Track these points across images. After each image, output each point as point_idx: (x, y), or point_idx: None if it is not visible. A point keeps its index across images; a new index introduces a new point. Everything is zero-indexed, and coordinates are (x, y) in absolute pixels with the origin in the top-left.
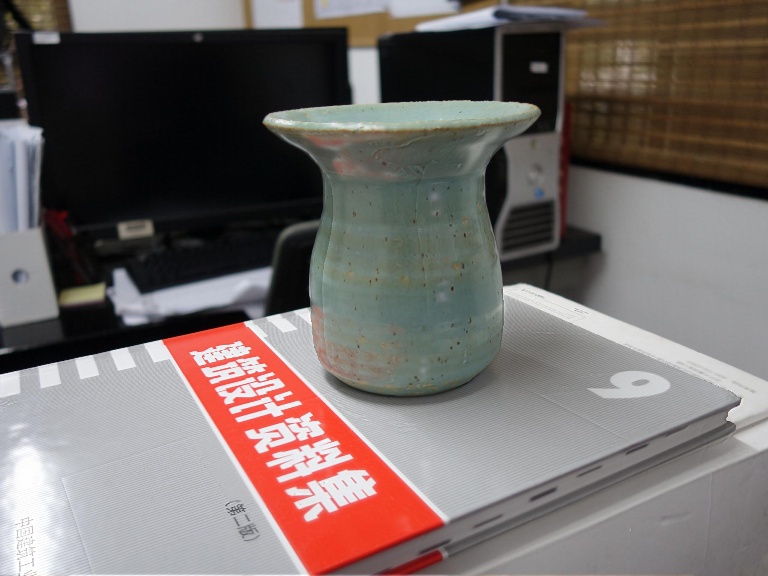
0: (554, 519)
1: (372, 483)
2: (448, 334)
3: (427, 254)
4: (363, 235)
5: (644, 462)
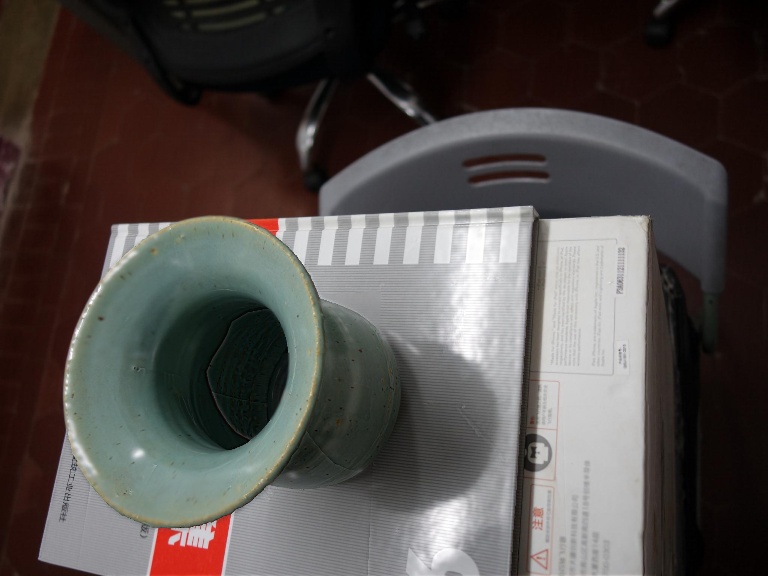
0: None
1: (211, 537)
2: None
3: None
4: None
5: None
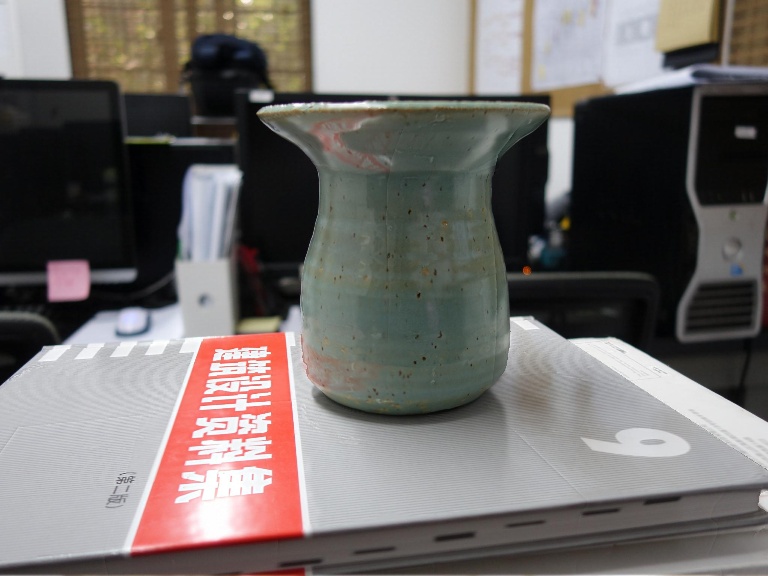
0: (468, 571)
1: (267, 483)
2: (412, 346)
3: (394, 254)
4: (335, 230)
5: (614, 532)
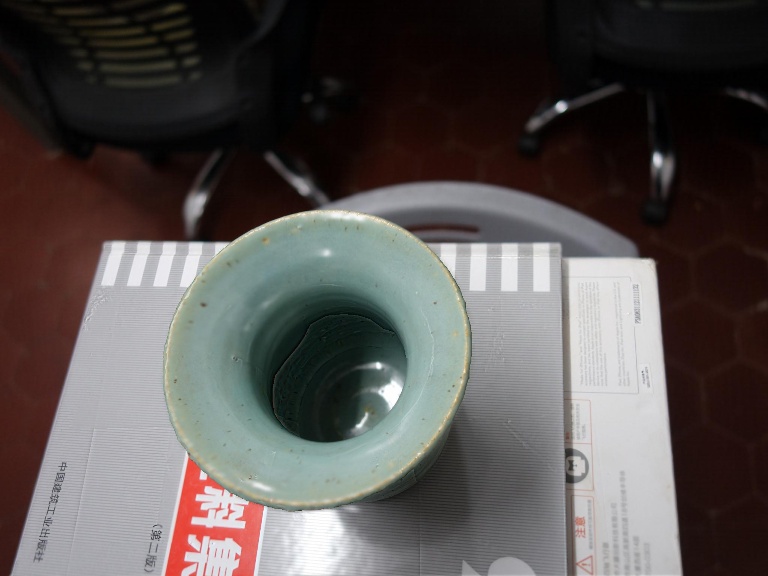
0: None
1: (236, 566)
2: None
3: None
4: None
5: None
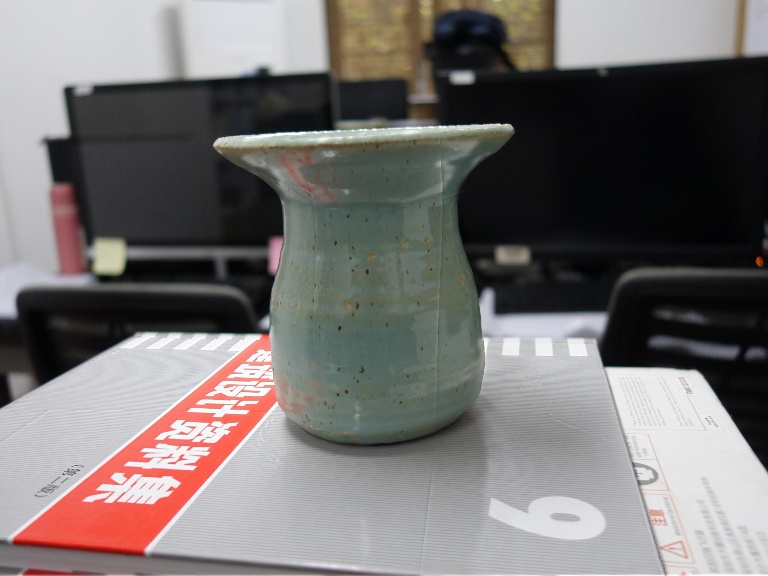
0: None
1: (165, 495)
2: (335, 378)
3: (319, 285)
4: (283, 256)
5: None
